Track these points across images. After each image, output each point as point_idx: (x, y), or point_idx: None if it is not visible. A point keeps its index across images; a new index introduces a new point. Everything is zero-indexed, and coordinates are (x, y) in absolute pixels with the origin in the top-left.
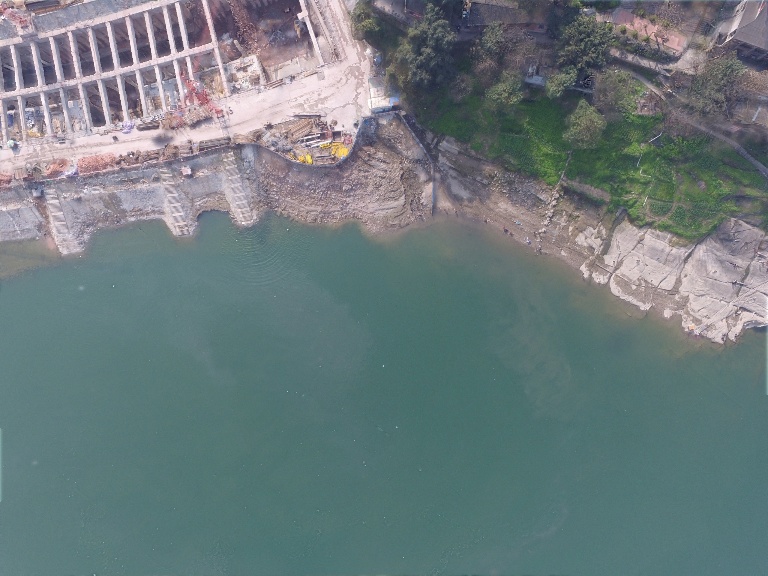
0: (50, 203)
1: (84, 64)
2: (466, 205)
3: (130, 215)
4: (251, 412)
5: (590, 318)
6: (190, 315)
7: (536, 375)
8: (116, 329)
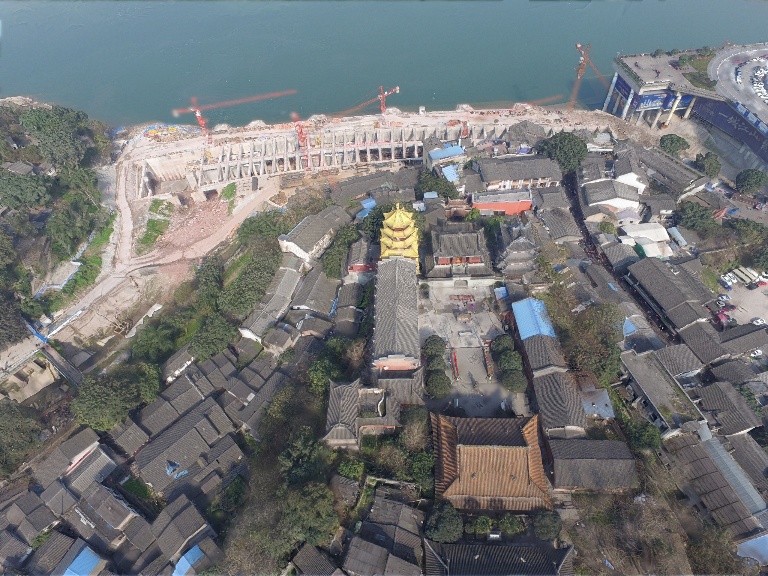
0: None
1: None
2: None
3: None
4: None
5: (73, 103)
6: None
7: None
8: (302, 94)
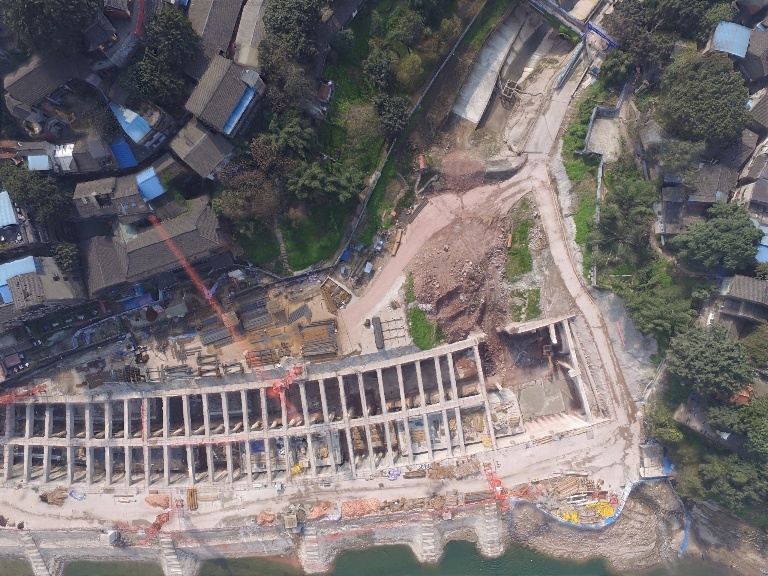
0: (307, 538)
1: None
2: (713, 550)
3: (378, 541)
4: None
5: None
6: None
7: None
8: None
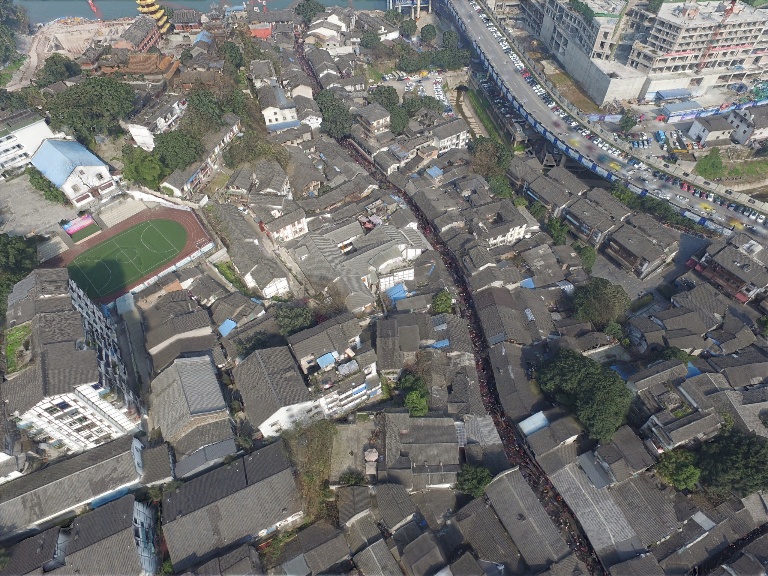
0: None
1: None
2: None
3: None
4: None
5: None
6: None
7: (40, 0)
8: None
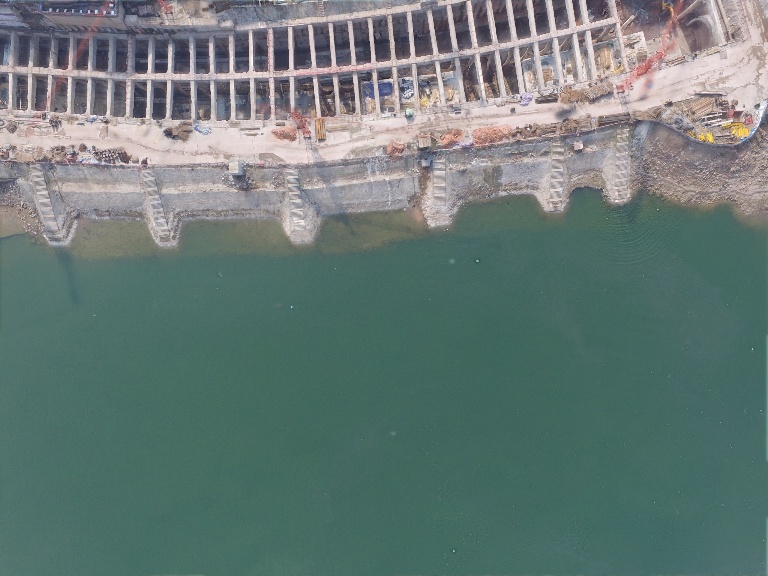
0: (436, 174)
1: (442, 35)
2: None
3: (503, 189)
4: (616, 391)
5: None
6: (555, 292)
7: None
8: (482, 304)
